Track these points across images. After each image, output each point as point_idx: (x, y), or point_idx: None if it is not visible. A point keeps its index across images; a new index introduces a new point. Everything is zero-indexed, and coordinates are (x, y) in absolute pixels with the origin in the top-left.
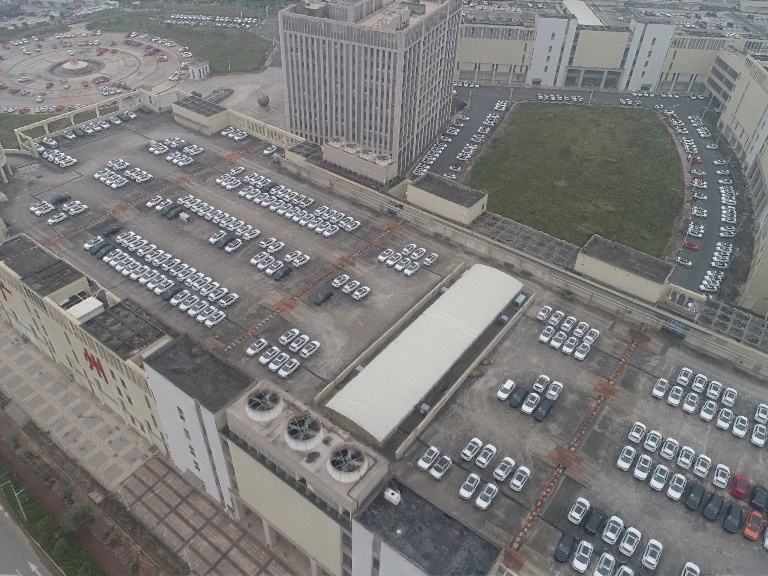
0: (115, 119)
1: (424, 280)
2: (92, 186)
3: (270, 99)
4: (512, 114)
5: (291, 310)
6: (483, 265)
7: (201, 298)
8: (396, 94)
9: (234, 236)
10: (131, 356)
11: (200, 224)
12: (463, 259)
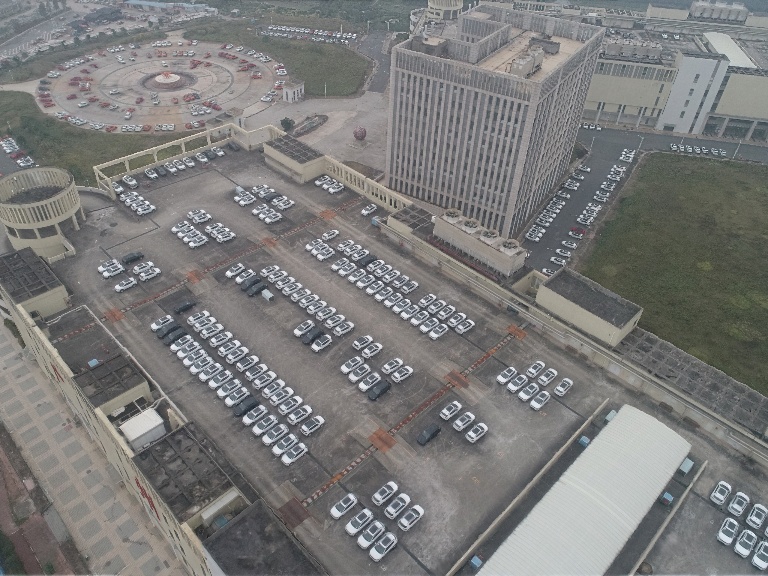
0: (201, 156)
1: (556, 418)
2: (168, 242)
3: (366, 130)
4: (641, 167)
5: (388, 449)
6: (636, 409)
7: (279, 418)
8: (520, 151)
9: (323, 328)
10: (189, 517)
11: (284, 306)
12: (605, 390)
